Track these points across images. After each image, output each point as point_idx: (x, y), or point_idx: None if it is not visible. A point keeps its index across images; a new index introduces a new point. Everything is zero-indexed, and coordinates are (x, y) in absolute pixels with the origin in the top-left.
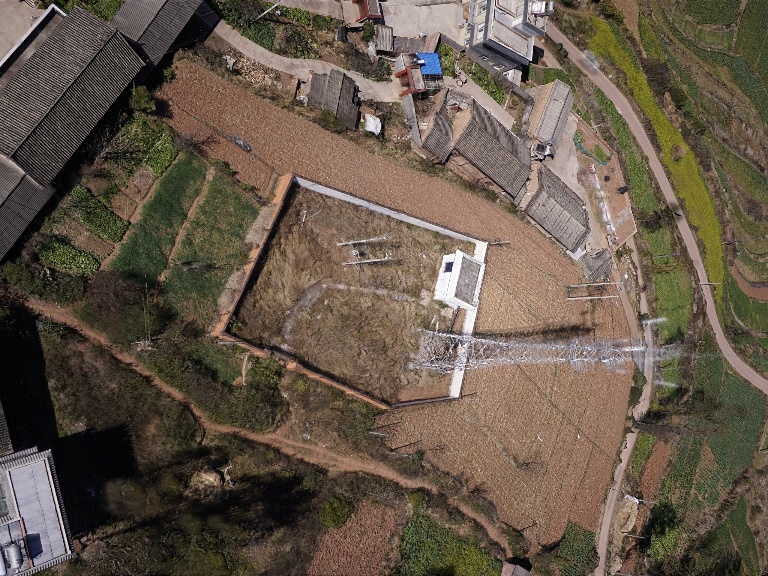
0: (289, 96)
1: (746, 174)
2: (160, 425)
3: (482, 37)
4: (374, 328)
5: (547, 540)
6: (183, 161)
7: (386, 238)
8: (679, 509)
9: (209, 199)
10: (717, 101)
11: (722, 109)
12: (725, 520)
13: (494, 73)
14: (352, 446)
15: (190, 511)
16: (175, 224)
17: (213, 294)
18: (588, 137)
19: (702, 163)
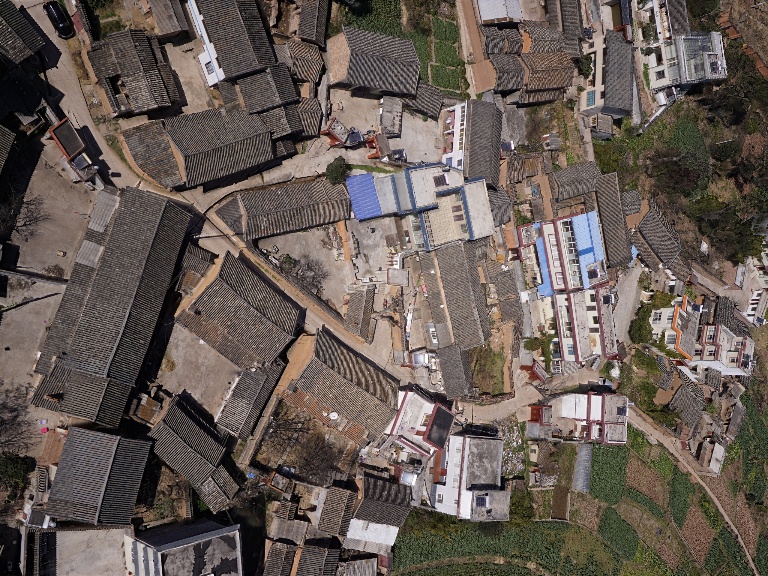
0: None
1: None
2: None
3: None
4: (762, 41)
5: None
6: None
7: None
8: None
9: None
10: None
11: None
12: None
13: None
14: None
15: (711, 103)
16: None
17: (717, 5)
18: None
19: None
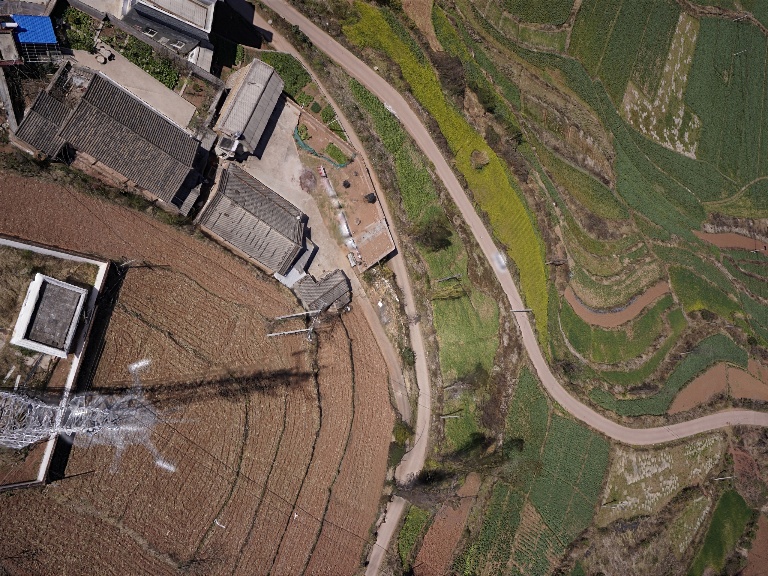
0: None
1: (586, 187)
2: None
3: None
4: None
5: None
6: None
7: None
8: None
9: None
10: (546, 106)
11: (553, 115)
12: None
13: (160, 49)
14: None
15: None
16: None
17: None
18: (317, 133)
19: (517, 172)
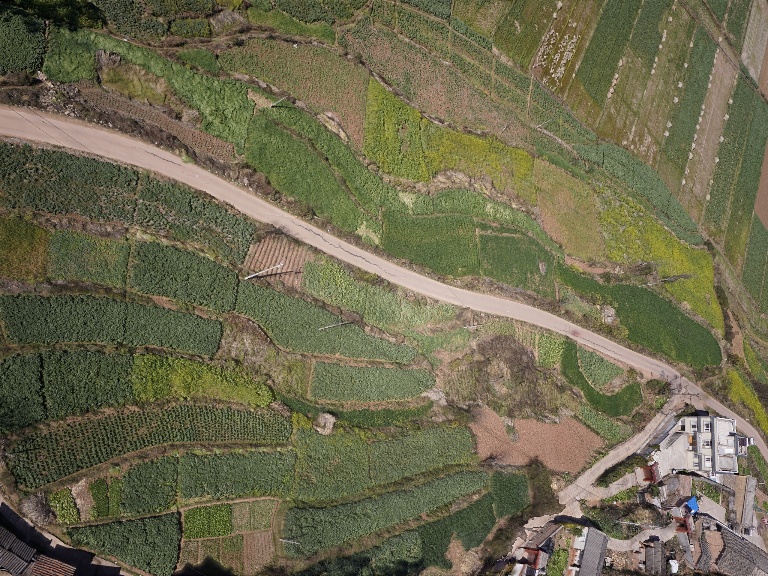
0: (633, 565)
1: None
2: None
3: (711, 467)
4: None
5: None
6: None
7: None
8: None
9: None
10: None
11: None
12: None
13: (715, 484)
14: None
15: None
16: None
17: None
18: (759, 497)
19: None
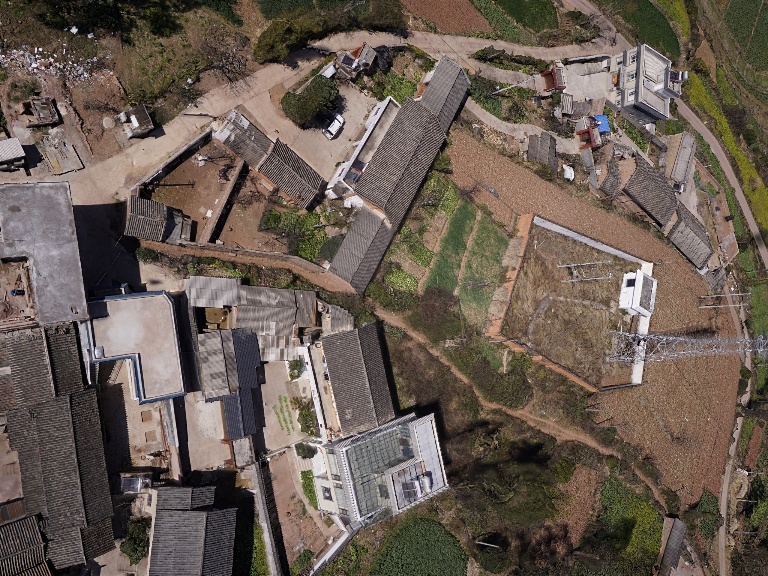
0: None
1: None
2: (459, 402)
3: (633, 100)
4: (584, 330)
5: (690, 501)
6: (463, 206)
7: (585, 261)
8: (766, 485)
9: (479, 234)
10: None
11: None
12: None
13: (640, 127)
14: (571, 421)
15: (475, 467)
16: (460, 253)
17: (485, 305)
18: (703, 176)
19: None
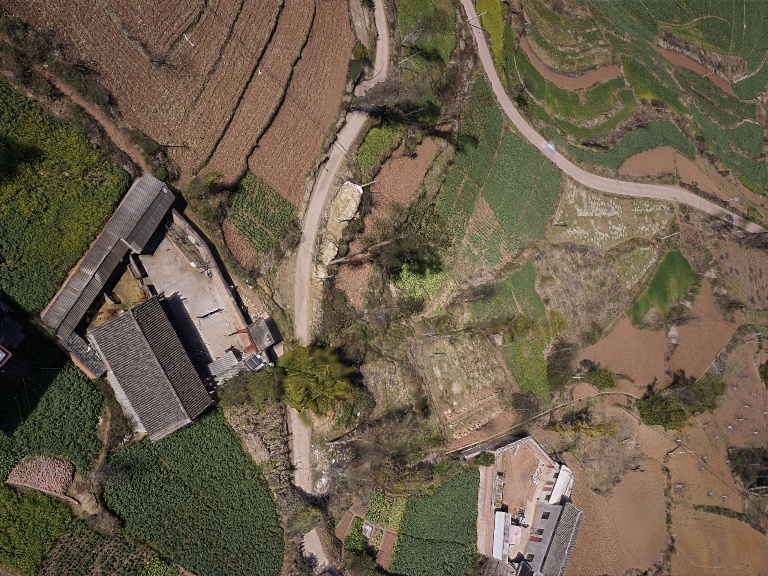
0: None
1: None
2: None
3: None
4: None
5: None
6: None
7: None
8: (447, 256)
9: None
10: None
11: None
12: (506, 279)
13: None
14: None
15: None
16: None
17: None
18: None
19: None
